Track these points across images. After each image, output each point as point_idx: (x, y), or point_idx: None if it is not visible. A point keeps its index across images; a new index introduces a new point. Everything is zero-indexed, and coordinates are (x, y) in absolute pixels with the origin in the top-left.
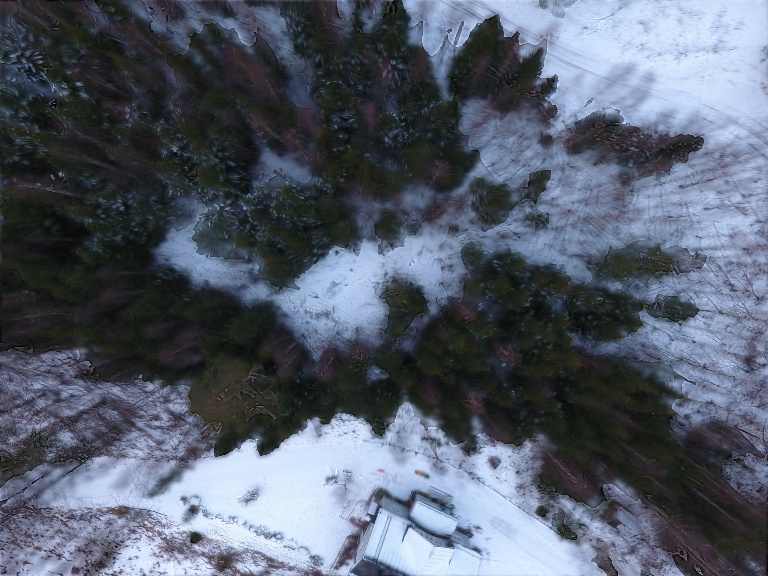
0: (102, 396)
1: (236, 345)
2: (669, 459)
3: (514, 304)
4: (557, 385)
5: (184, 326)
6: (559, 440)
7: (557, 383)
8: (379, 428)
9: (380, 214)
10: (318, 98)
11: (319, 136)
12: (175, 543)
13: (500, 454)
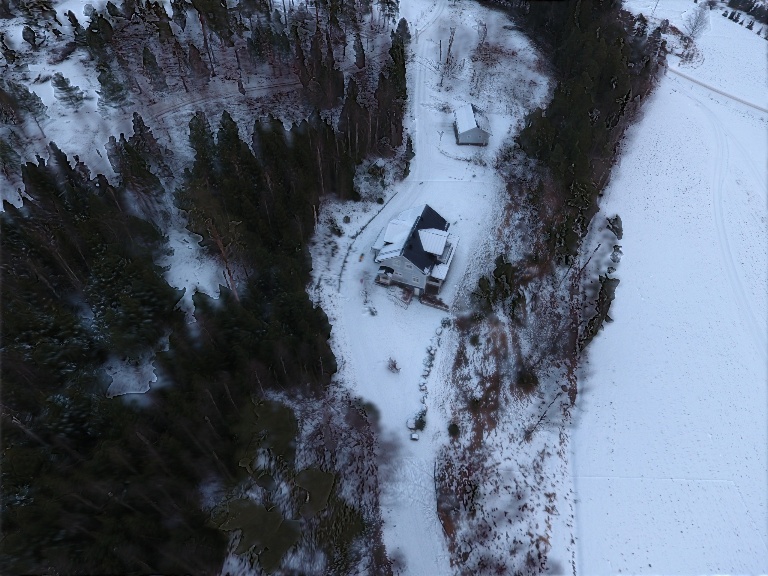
0: (295, 512)
1: (217, 312)
2: (323, 136)
3: (210, 171)
4: (274, 169)
5: (186, 328)
6: (305, 164)
7: (273, 169)
8: (300, 244)
9: (132, 223)
10: (31, 254)
11: (56, 231)
12: (473, 462)
13: (341, 218)
